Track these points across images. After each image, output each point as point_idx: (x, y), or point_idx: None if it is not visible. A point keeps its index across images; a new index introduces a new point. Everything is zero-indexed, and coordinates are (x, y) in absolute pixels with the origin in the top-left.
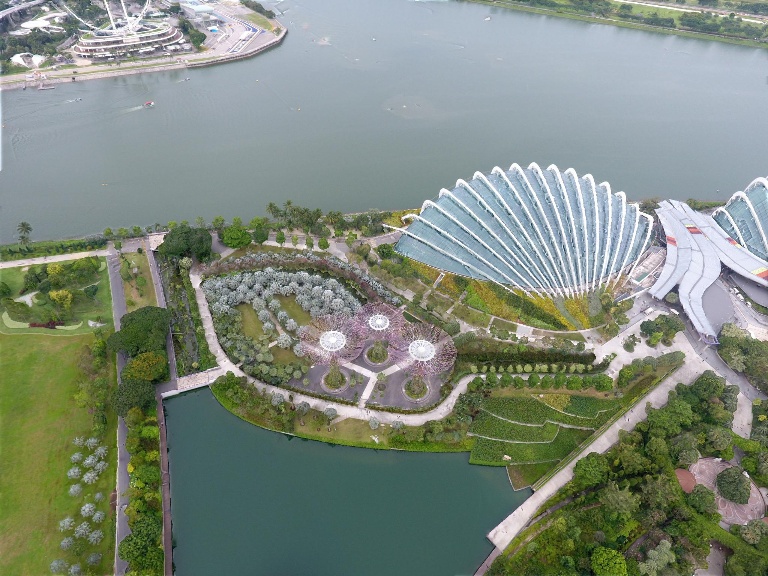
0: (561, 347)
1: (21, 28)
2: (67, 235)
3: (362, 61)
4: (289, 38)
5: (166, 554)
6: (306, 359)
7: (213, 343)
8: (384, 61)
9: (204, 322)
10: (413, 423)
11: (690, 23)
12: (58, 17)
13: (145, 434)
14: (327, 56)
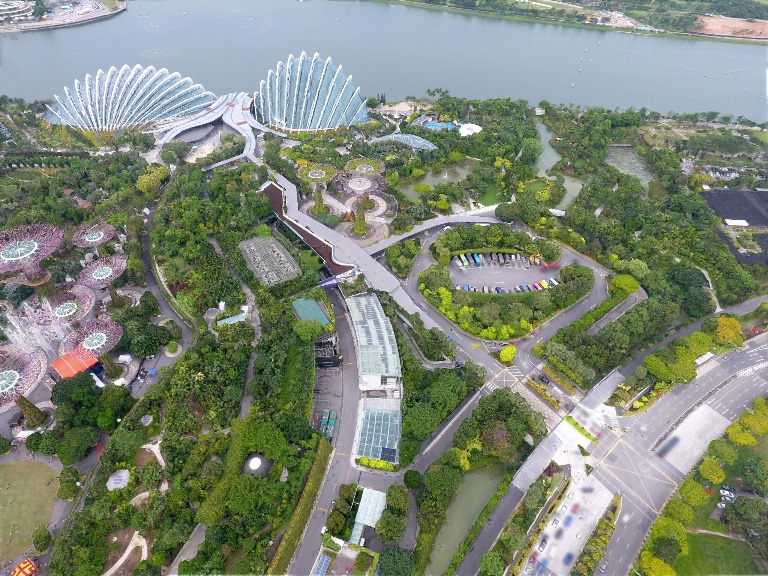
0: (68, 148)
1: None
2: None
3: (161, 27)
4: (127, 15)
5: None
6: None
7: None
8: (178, 27)
9: None
10: None
11: (454, 1)
12: None
13: None
14: (137, 24)
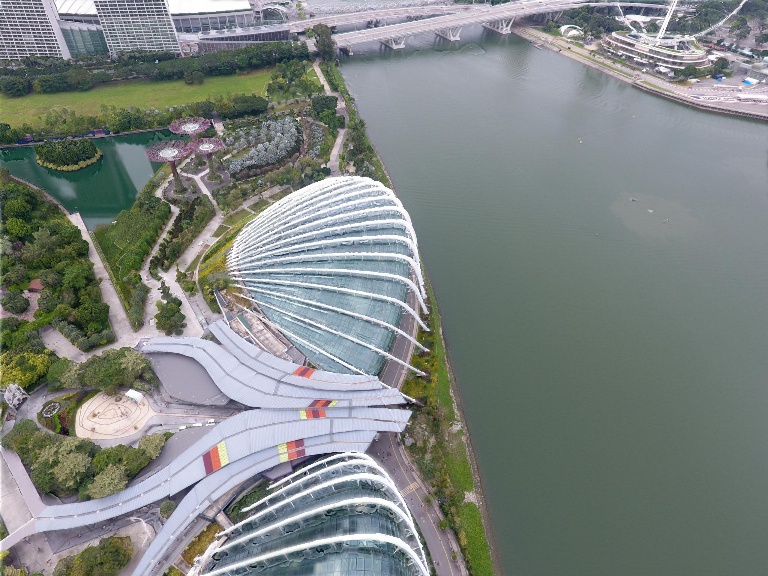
0: None
1: None
2: (352, 84)
3: None
4: None
5: None
6: None
7: None
8: None
9: None
10: (158, 191)
11: None
12: None
13: None
14: None
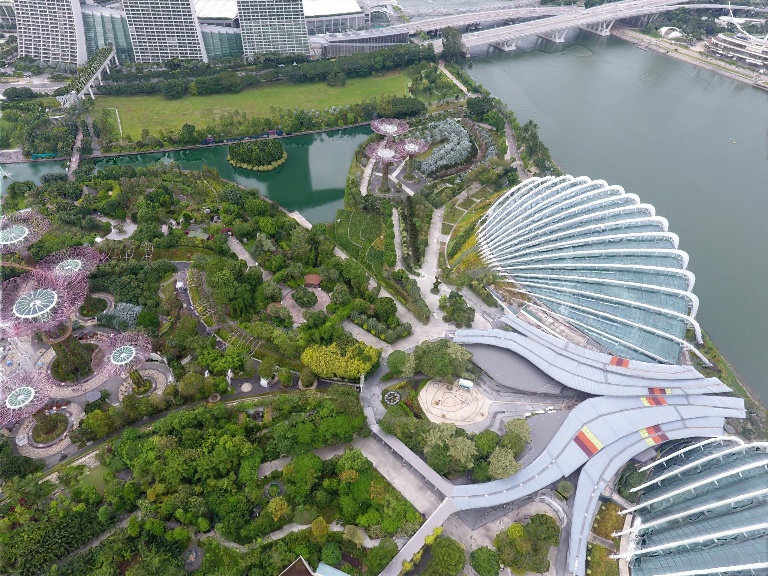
0: None
1: (716, 18)
2: None
3: None
4: None
5: None
6: None
7: None
8: None
9: None
10: (361, 190)
11: None
12: (759, 22)
13: (348, 114)
14: None
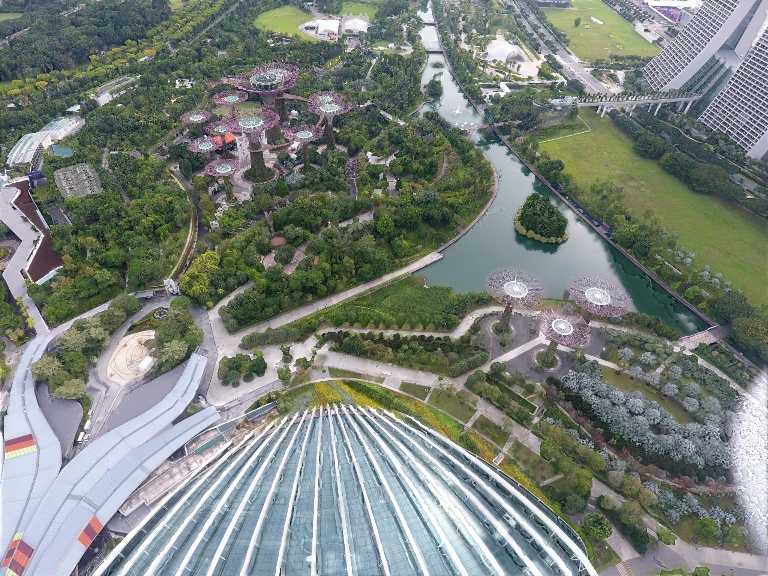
0: None
1: None
2: None
3: None
4: None
5: (624, 252)
6: (614, 344)
7: (720, 376)
8: None
9: (755, 401)
10: (499, 308)
11: None
12: None
13: None
14: None
